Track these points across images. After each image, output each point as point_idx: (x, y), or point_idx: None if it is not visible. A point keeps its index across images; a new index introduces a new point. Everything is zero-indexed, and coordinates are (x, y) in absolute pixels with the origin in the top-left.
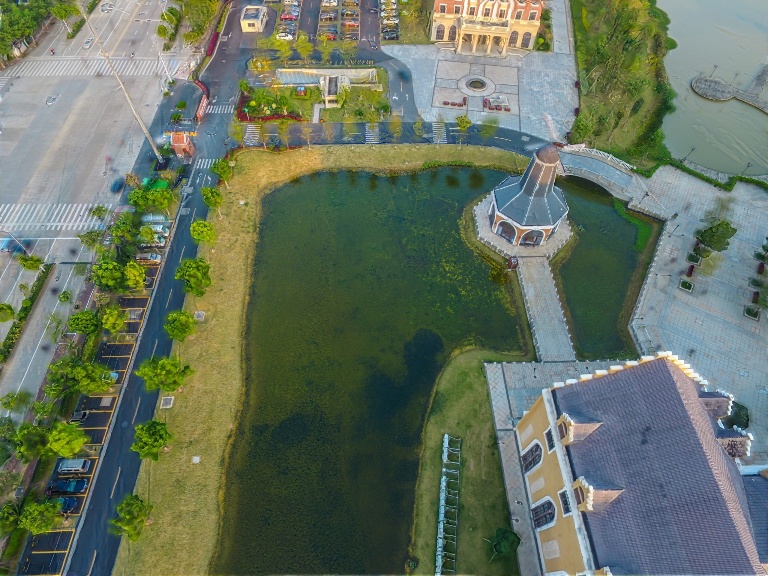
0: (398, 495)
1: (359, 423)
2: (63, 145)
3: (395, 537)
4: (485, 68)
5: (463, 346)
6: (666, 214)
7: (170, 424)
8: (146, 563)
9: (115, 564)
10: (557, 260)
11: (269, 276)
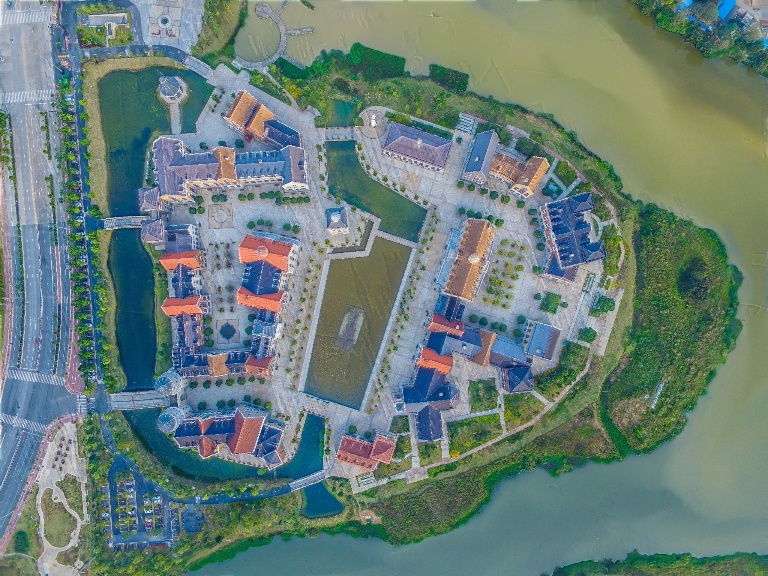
0: (141, 165)
1: (132, 151)
2: (27, 64)
3: (141, 172)
4: (169, 9)
5: (156, 131)
6: (215, 85)
7: (91, 153)
8: (95, 178)
9: (89, 178)
10: (182, 103)
11: (105, 113)
